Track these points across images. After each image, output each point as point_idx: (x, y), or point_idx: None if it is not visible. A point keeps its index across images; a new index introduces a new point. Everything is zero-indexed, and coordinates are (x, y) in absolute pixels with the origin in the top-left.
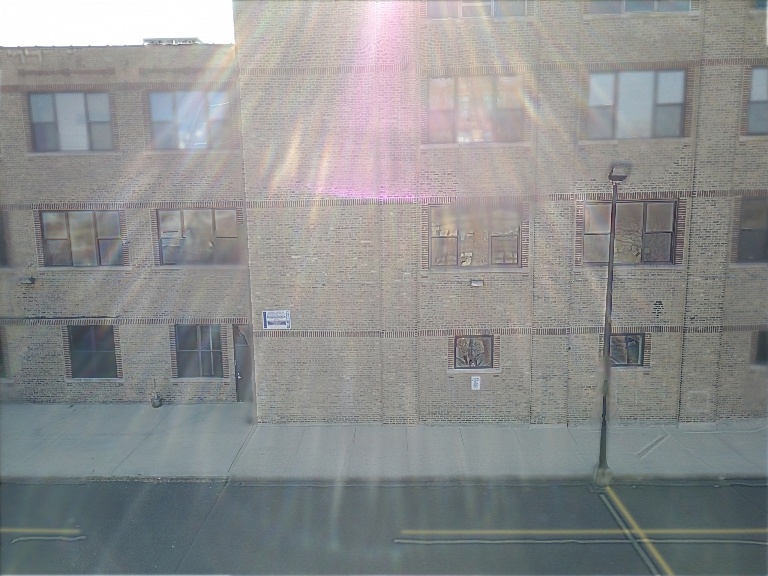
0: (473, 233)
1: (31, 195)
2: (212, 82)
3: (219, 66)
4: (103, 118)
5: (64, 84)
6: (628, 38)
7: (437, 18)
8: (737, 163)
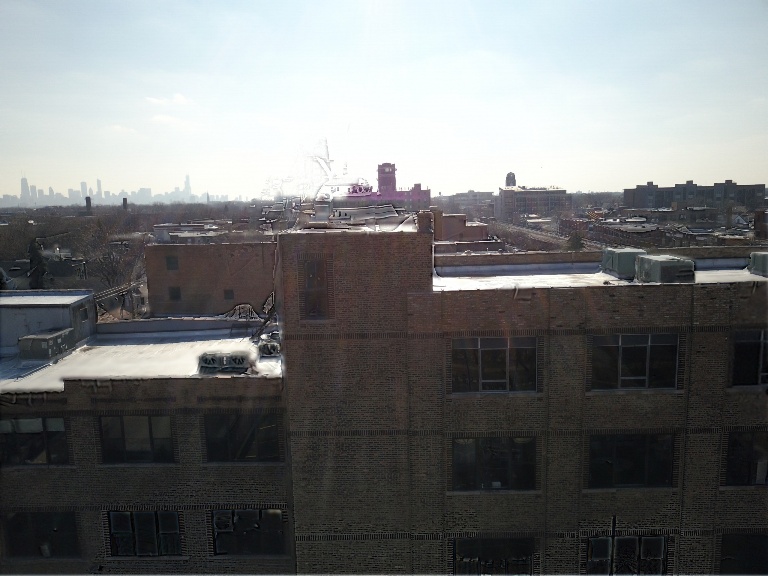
0: (492, 562)
1: (100, 498)
2: (261, 408)
3: (267, 395)
4: (165, 435)
5: (131, 410)
6: (624, 410)
7: (460, 392)
8: (718, 507)
